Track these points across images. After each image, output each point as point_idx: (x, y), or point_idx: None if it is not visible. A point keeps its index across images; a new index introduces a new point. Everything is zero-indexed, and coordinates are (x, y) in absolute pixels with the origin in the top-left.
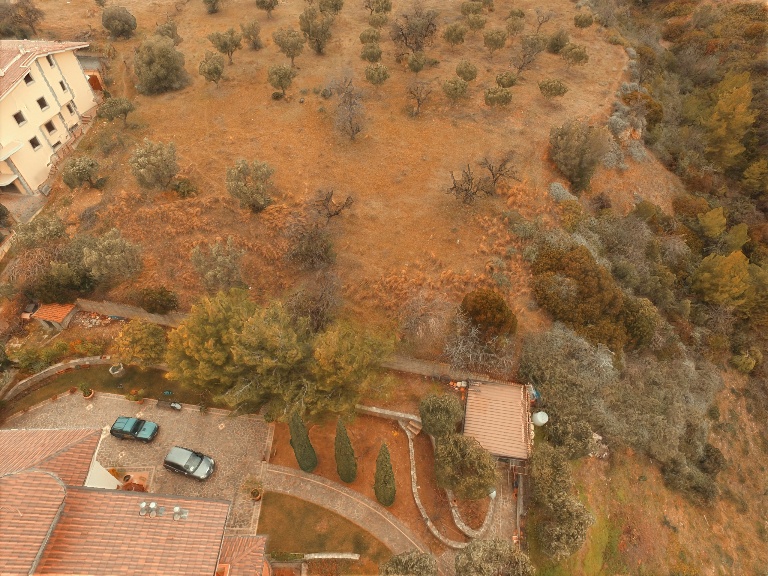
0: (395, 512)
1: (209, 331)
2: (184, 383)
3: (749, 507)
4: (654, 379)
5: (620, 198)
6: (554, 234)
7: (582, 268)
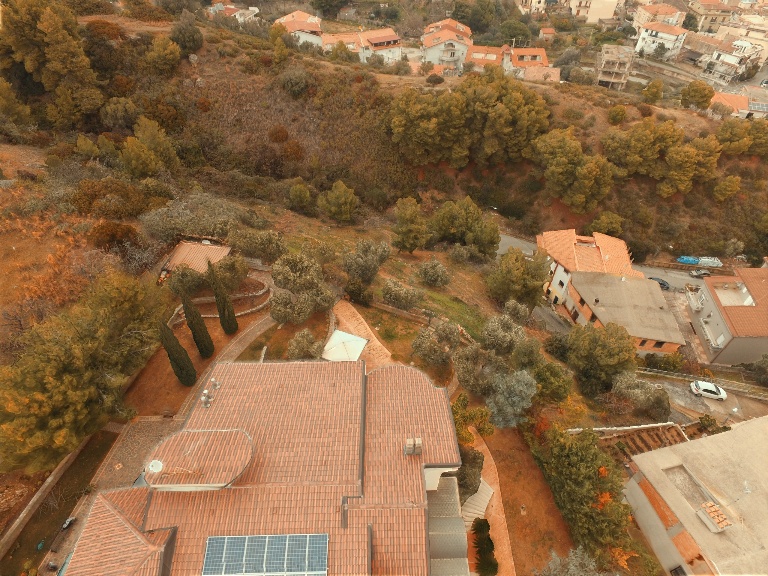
0: (242, 328)
1: (32, 382)
2: (73, 437)
3: (278, 221)
4: (198, 203)
5: (28, 171)
6: (55, 192)
7: (102, 187)
